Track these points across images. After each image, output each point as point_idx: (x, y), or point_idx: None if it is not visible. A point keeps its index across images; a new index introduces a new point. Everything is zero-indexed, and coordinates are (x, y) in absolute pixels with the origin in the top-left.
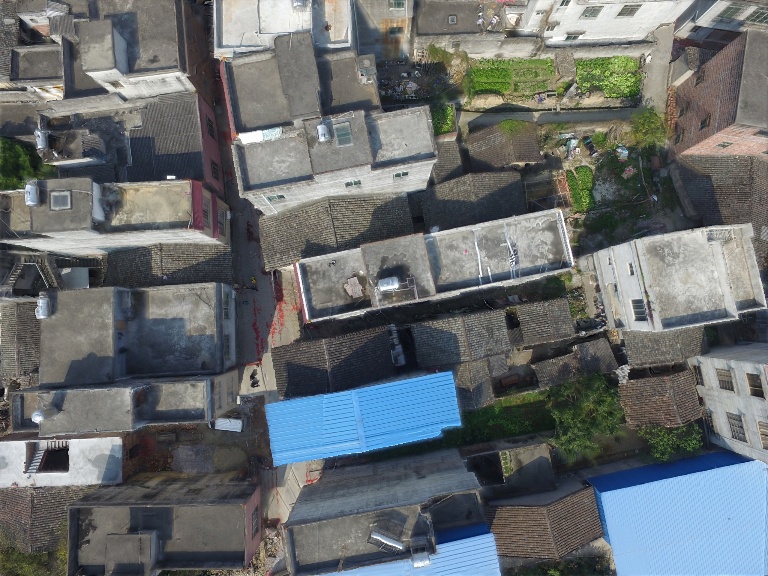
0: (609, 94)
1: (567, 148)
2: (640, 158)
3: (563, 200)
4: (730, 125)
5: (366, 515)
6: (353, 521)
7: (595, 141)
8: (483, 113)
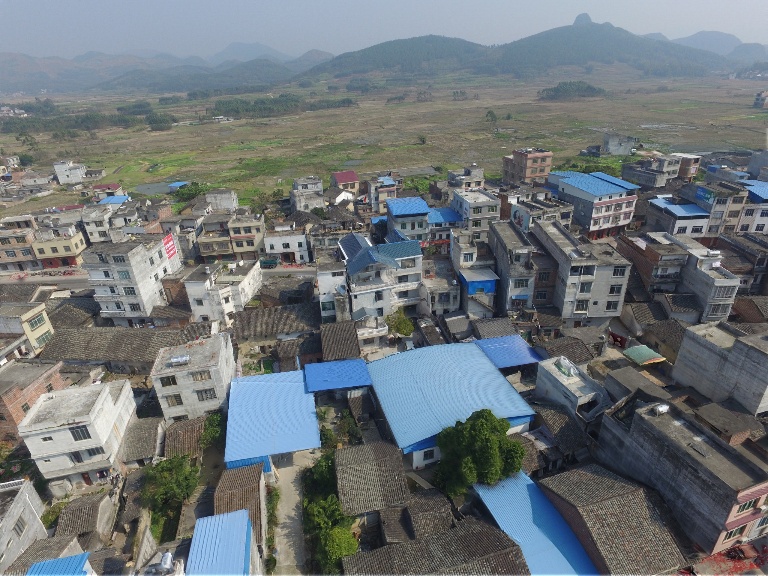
0: None
1: None
2: (11, 462)
3: None
4: (2, 398)
5: None
6: None
7: None
8: None
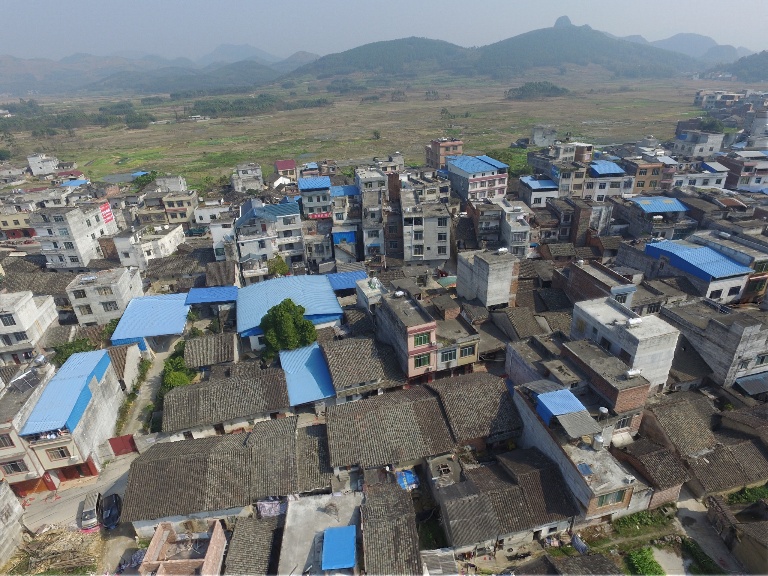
0: None
1: None
2: None
3: None
4: None
5: (6, 395)
6: (4, 401)
7: None
8: None
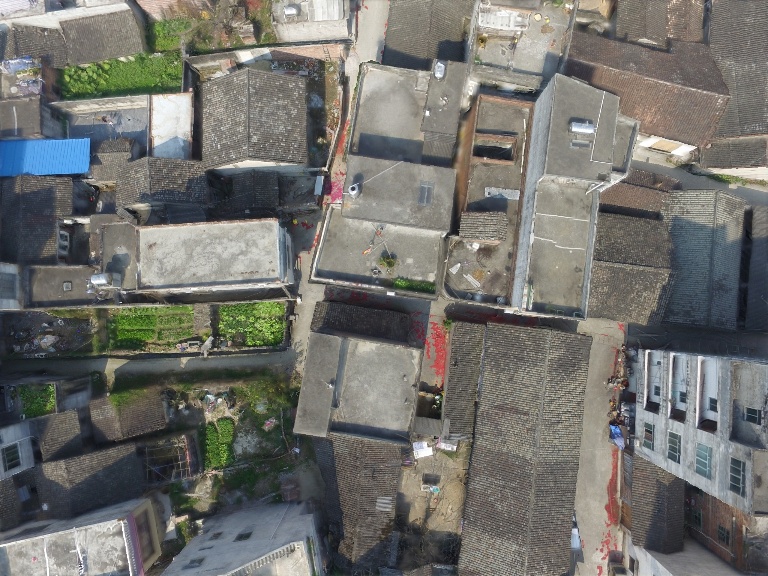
0: (252, 342)
1: (205, 402)
2: (281, 409)
3: (181, 470)
4: None
5: None
6: None
7: (238, 391)
8: (130, 360)
